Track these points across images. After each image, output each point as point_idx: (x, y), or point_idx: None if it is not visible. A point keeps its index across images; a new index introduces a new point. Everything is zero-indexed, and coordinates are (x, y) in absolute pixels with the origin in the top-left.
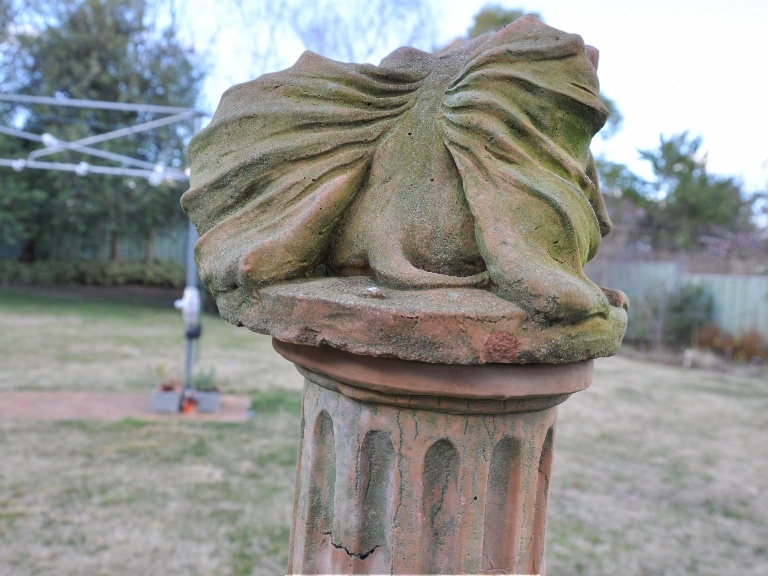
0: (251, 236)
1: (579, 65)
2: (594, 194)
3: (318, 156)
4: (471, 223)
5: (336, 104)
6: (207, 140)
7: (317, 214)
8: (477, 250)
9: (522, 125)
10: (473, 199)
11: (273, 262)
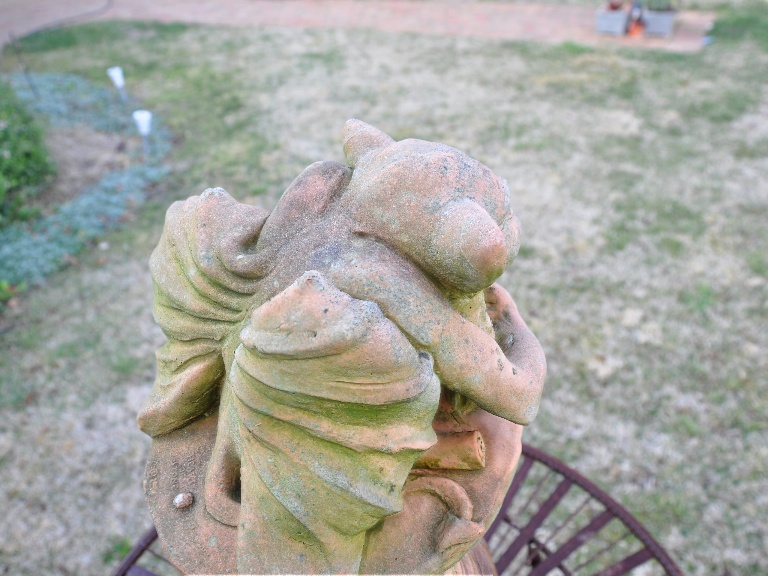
0: (158, 386)
1: (345, 363)
2: (419, 449)
3: (185, 341)
4: None
5: (196, 293)
6: None
7: (182, 396)
8: None
9: (277, 418)
10: None
11: (157, 425)
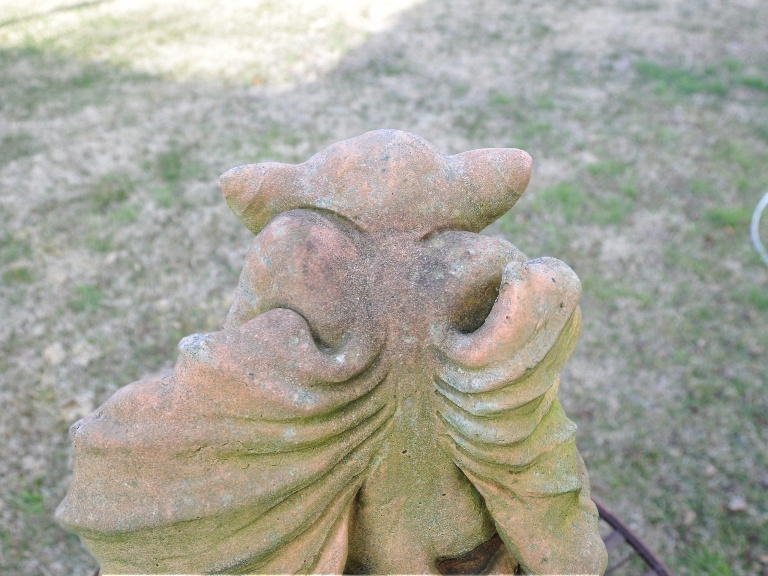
0: None
1: None
2: None
3: (308, 527)
4: (489, 517)
5: (303, 454)
6: (116, 539)
7: None
8: (495, 531)
9: None
10: (504, 523)
11: None
